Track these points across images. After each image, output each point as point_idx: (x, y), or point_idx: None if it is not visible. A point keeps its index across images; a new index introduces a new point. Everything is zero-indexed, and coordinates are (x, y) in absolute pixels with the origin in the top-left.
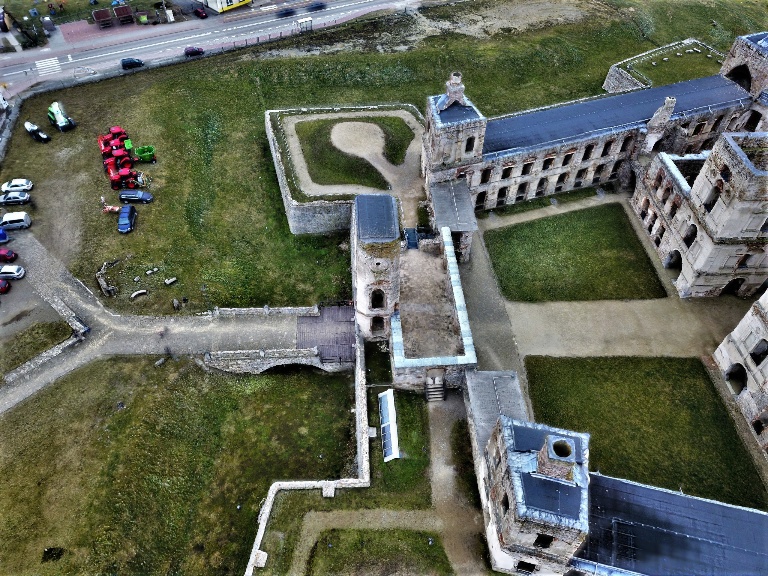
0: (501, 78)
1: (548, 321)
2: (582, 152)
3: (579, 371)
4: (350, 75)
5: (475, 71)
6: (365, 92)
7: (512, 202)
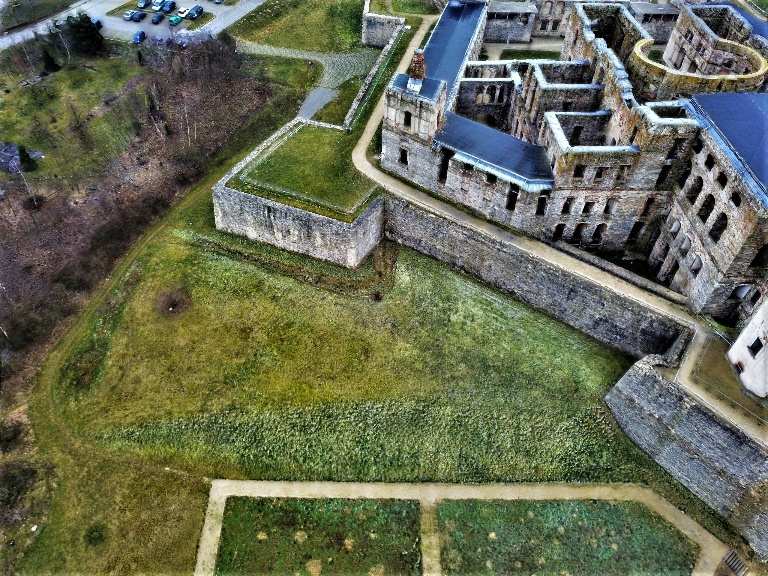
0: None
1: None
2: None
3: None
4: None
5: None
6: None
7: None
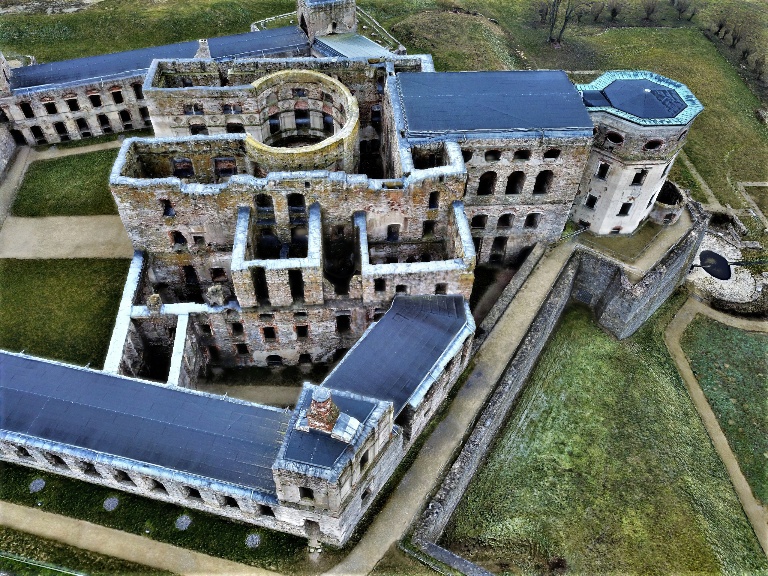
0: (157, 37)
1: (35, 232)
2: (130, 90)
3: (32, 270)
4: (8, 34)
5: (133, 30)
6: (16, 48)
7: (78, 138)
